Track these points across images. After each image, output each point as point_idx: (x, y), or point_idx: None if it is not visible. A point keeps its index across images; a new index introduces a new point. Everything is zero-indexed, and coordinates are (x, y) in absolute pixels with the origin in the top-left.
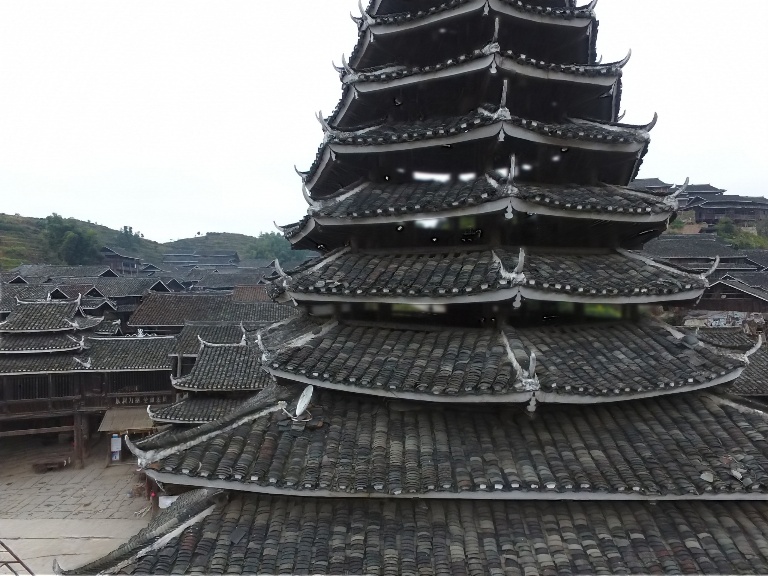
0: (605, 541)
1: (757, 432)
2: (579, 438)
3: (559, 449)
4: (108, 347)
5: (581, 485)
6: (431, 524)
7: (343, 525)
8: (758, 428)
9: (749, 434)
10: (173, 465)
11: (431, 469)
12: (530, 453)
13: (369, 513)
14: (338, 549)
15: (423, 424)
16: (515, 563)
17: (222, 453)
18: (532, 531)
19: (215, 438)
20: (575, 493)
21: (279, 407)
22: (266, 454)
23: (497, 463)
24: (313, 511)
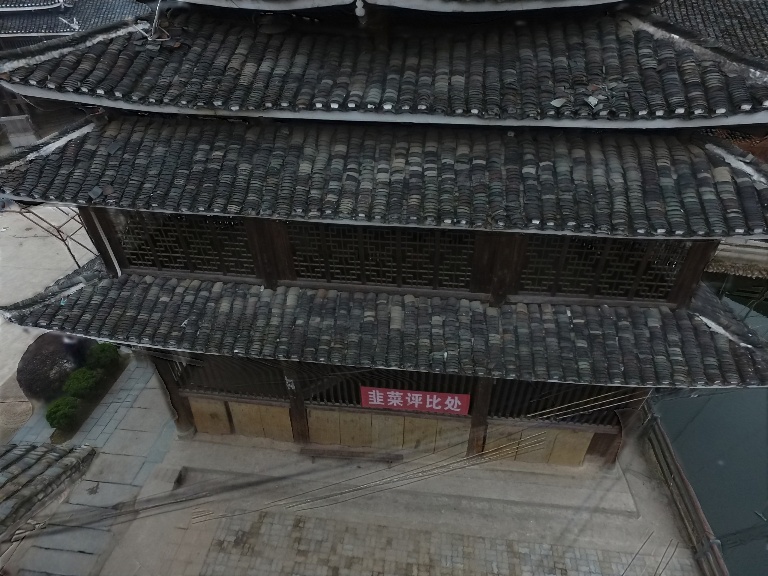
0: (445, 165)
1: (654, 59)
2: (448, 64)
3: (420, 74)
4: (92, 5)
5: (418, 106)
6: (288, 146)
7: (207, 143)
8: (660, 55)
9: (643, 61)
10: (18, 76)
11: (275, 89)
12: (386, 77)
13: (233, 135)
14: (198, 161)
15: (285, 47)
16: (354, 178)
17: (73, 69)
18: (380, 155)
19: (67, 55)
20: (413, 115)
21: (139, 27)
22: (117, 71)
23: (347, 86)
24: (183, 132)
